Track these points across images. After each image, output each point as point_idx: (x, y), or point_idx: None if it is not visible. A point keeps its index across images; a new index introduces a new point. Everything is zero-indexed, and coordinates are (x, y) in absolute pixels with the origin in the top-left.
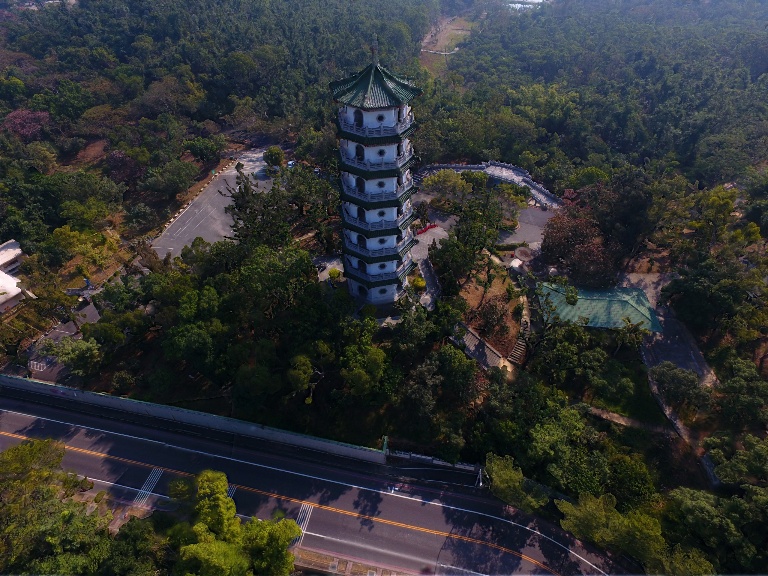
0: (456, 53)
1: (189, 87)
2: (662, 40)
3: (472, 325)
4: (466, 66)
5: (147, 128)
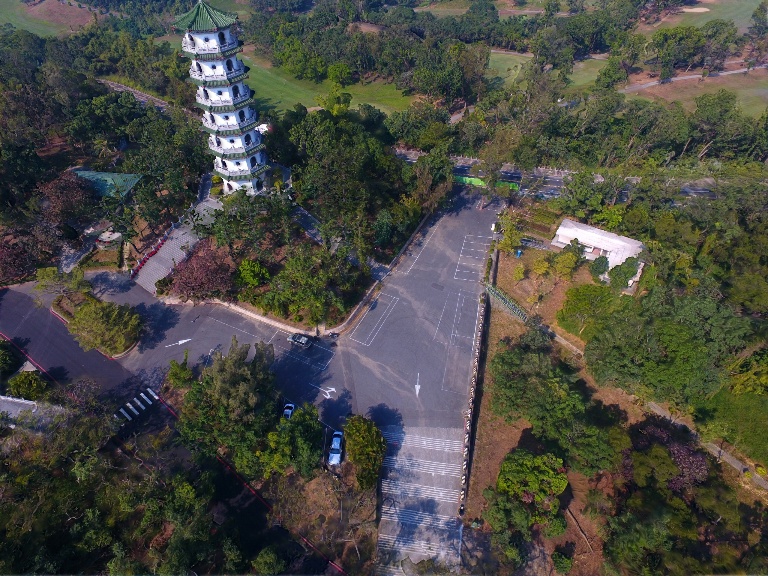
0: None
1: None
2: None
3: None
4: None
5: None
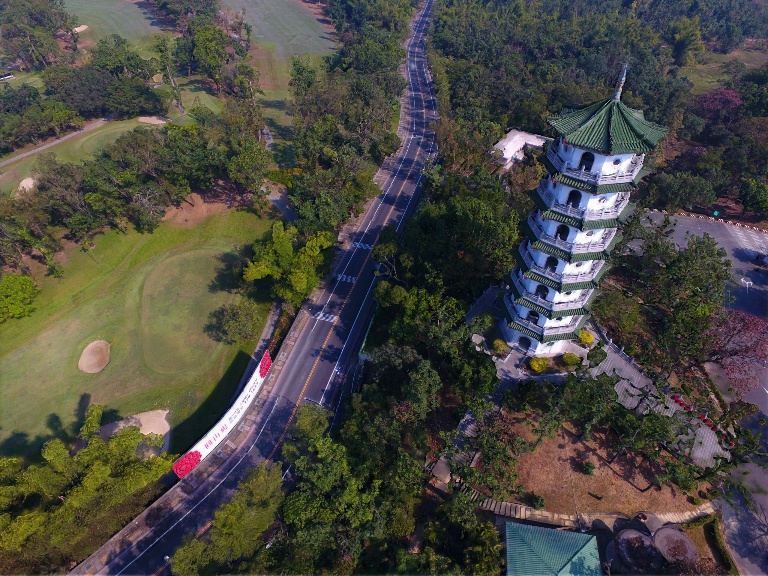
0: None
1: None
2: None
3: None
4: None
5: (763, 154)
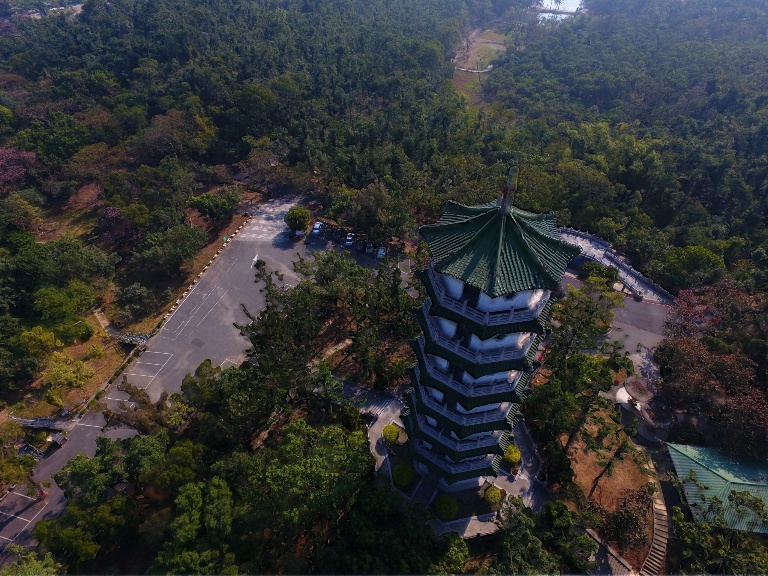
0: (492, 73)
1: (197, 122)
2: (727, 62)
3: None
4: (505, 89)
5: (147, 177)
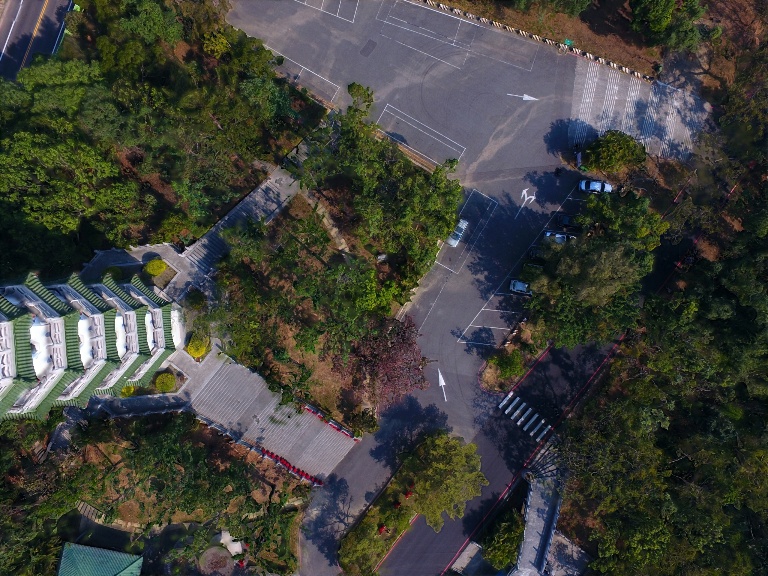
0: None
1: None
2: None
3: (90, 445)
4: None
5: None
